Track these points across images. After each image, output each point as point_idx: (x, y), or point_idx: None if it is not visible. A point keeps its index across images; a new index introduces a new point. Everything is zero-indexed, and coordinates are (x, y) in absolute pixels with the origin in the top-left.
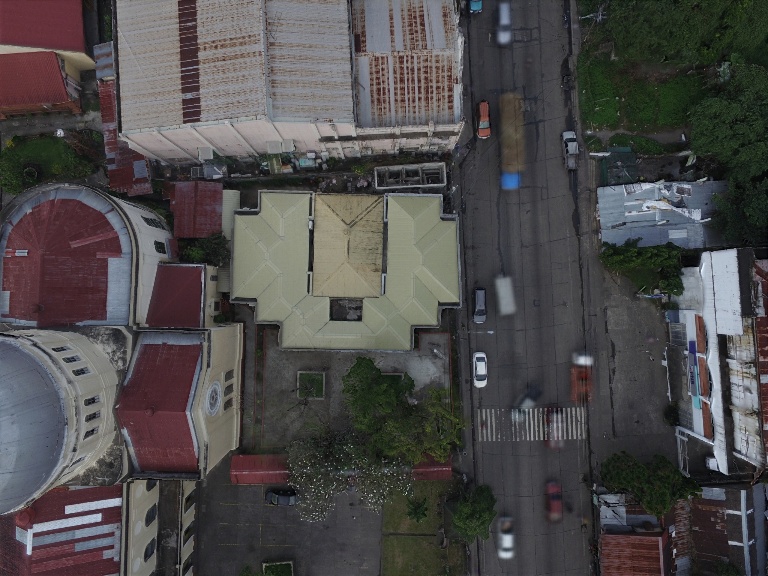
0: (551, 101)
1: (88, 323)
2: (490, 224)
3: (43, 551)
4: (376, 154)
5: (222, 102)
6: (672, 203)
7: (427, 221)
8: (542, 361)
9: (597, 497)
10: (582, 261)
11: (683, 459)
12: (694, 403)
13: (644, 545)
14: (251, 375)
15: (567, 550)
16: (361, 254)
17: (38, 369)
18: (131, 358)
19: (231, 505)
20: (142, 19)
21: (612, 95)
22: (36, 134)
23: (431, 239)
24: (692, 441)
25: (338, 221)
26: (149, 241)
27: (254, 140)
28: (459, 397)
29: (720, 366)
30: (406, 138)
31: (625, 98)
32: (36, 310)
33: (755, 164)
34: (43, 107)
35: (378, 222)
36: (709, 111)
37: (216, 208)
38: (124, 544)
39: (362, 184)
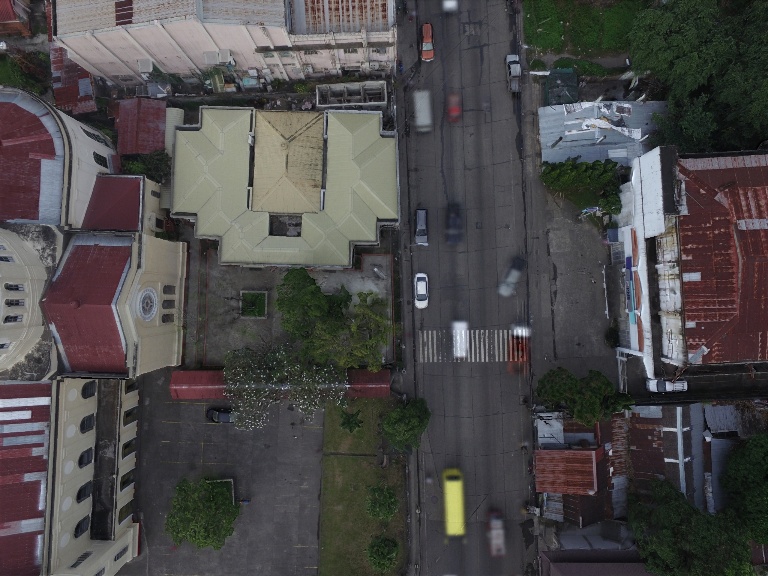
0: (496, 25)
1: (19, 221)
2: (434, 147)
3: None
4: (320, 75)
5: (153, 3)
6: (612, 122)
7: (366, 137)
8: (484, 283)
9: None
10: None
11: (623, 380)
12: (630, 319)
13: (578, 459)
14: (195, 295)
15: (507, 471)
16: (300, 169)
17: None
18: (62, 257)
19: (173, 423)
20: None
21: (556, 19)
22: None
23: (370, 155)
24: (633, 364)
25: (277, 136)
26: (87, 150)
27: (191, 50)
28: (400, 318)
29: (648, 271)
30: (344, 52)
31: (569, 22)
32: None
33: (690, 77)
34: None
35: (318, 138)
36: (643, 23)
37: (159, 125)
38: (53, 441)
39: (307, 106)
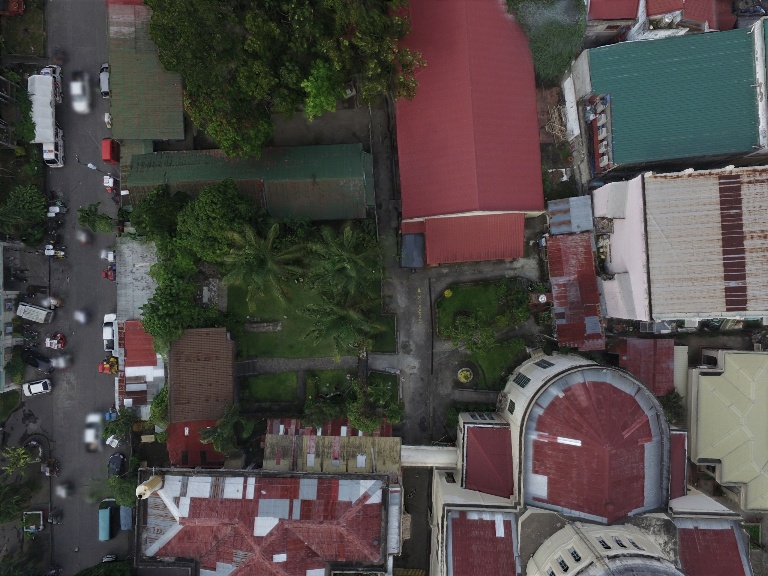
0: None
1: (635, 512)
2: None
3: None
4: None
5: None
6: None
7: None
8: None
9: None
10: None
11: None
12: None
13: None
14: None
15: None
16: None
17: None
18: None
19: None
20: (676, 203)
21: None
22: (466, 281)
23: None
24: None
25: None
26: None
27: None
28: None
29: None
30: None
31: None
32: None
33: None
34: None
35: None
36: None
37: (669, 365)
38: None
39: None
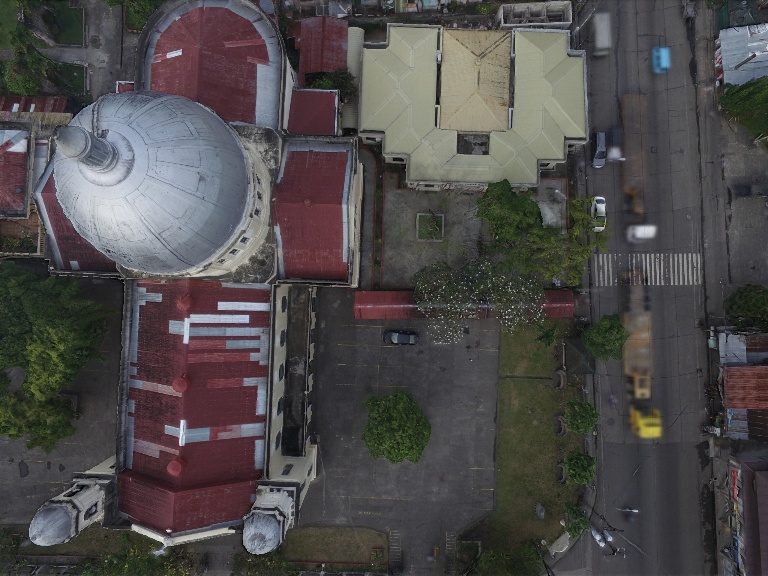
0: None
1: (240, 124)
2: (608, 71)
3: (198, 343)
4: None
5: None
6: None
7: (555, 56)
8: (659, 207)
9: (715, 339)
10: (699, 109)
11: None
12: None
13: None
14: (370, 218)
15: (683, 394)
16: (490, 86)
17: None
18: (281, 161)
19: (349, 346)
20: None
21: None
22: None
23: (560, 72)
24: None
25: (468, 53)
26: (287, 61)
27: None
28: None
29: None
30: None
31: None
32: (196, 100)
33: None
34: None
35: (505, 57)
36: None
37: (342, 45)
38: (271, 347)
39: None
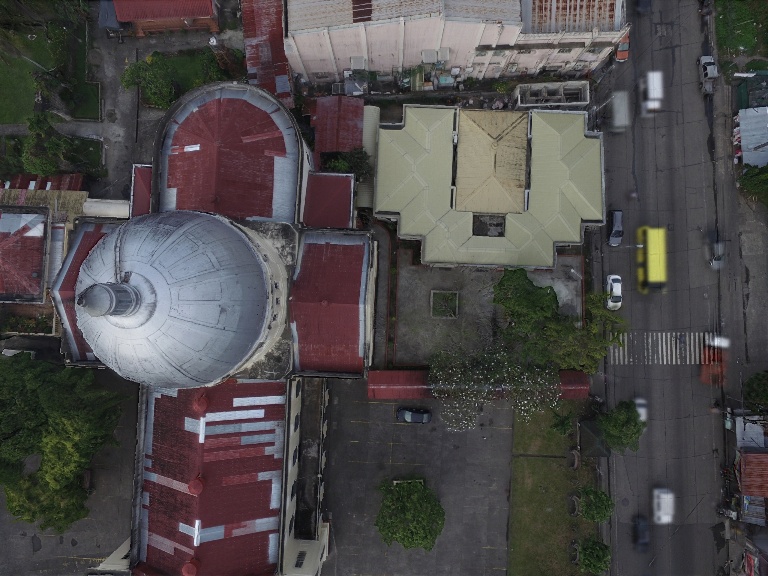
0: (687, 26)
1: (256, 219)
2: (625, 148)
3: (214, 441)
4: (514, 75)
5: (395, 1)
6: None
7: (572, 138)
8: (675, 285)
9: (732, 421)
10: (717, 186)
11: None
12: None
13: None
14: (384, 294)
15: (698, 474)
16: (506, 169)
17: (243, 241)
18: (297, 255)
19: (362, 423)
20: None
21: (750, 21)
22: (173, 51)
23: (577, 155)
24: None
25: (484, 135)
26: (304, 147)
27: (411, 48)
28: None
29: None
30: (557, 51)
31: (763, 24)
32: (214, 200)
33: None
34: (184, 23)
35: (522, 138)
36: None
37: (357, 123)
38: (286, 441)
39: (497, 106)
